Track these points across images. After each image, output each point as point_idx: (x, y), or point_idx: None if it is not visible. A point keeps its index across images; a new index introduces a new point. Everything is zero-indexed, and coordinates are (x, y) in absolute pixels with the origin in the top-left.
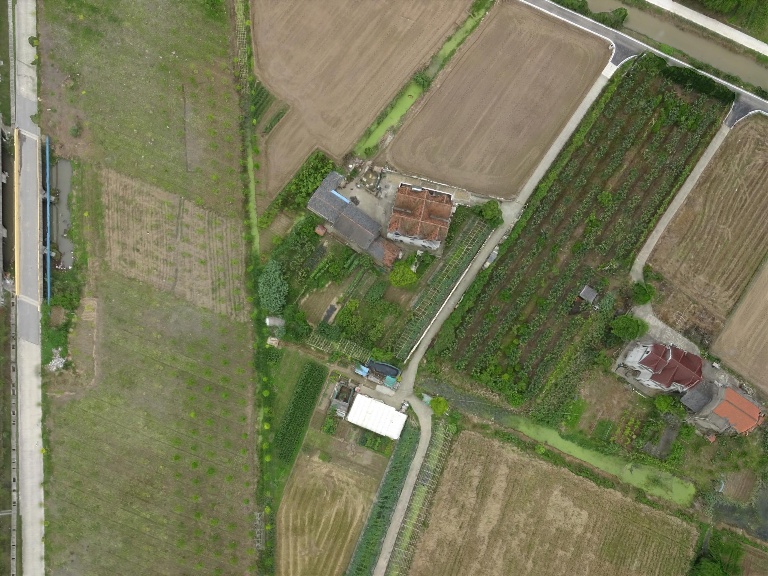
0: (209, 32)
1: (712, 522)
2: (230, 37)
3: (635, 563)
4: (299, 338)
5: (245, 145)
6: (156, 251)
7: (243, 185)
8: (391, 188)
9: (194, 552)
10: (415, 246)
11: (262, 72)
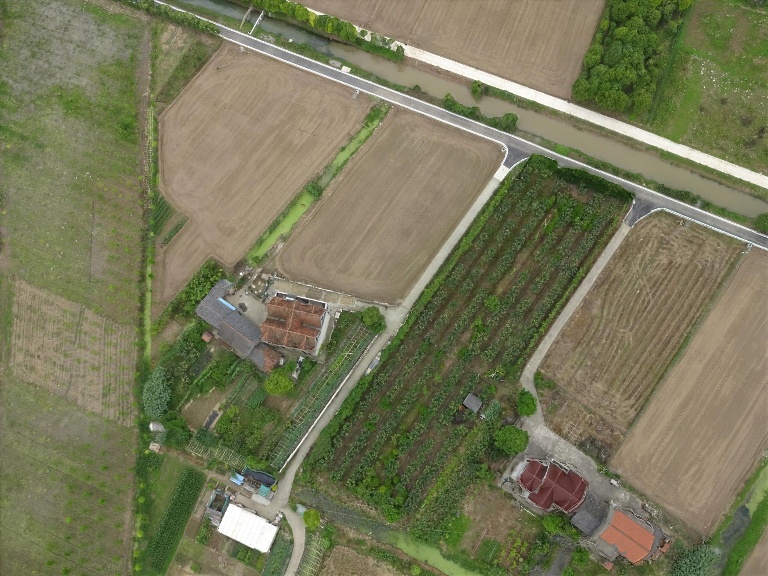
0: (121, 153)
1: None
2: (140, 157)
3: None
4: (180, 444)
5: (145, 256)
6: (55, 357)
7: (140, 293)
8: None
9: None
10: (297, 352)
11: (166, 187)
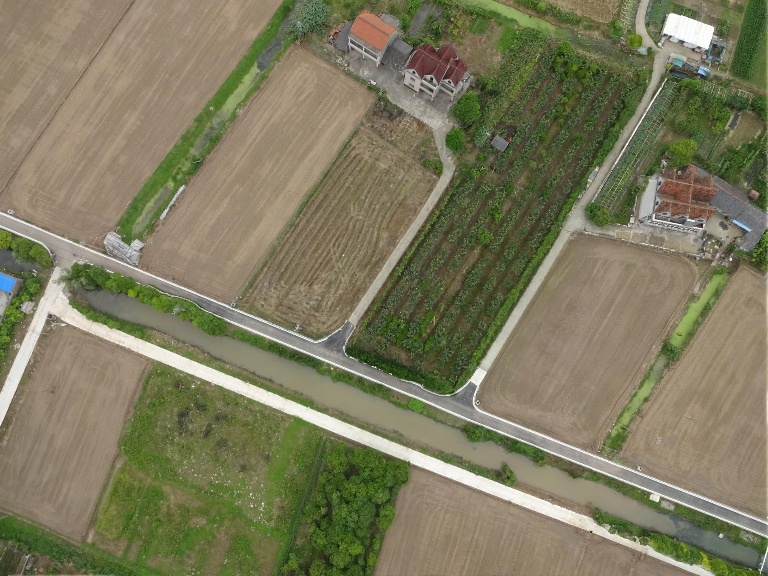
0: None
1: None
2: None
3: None
4: (760, 99)
5: None
6: None
7: None
8: (691, 240)
9: None
10: None
11: None
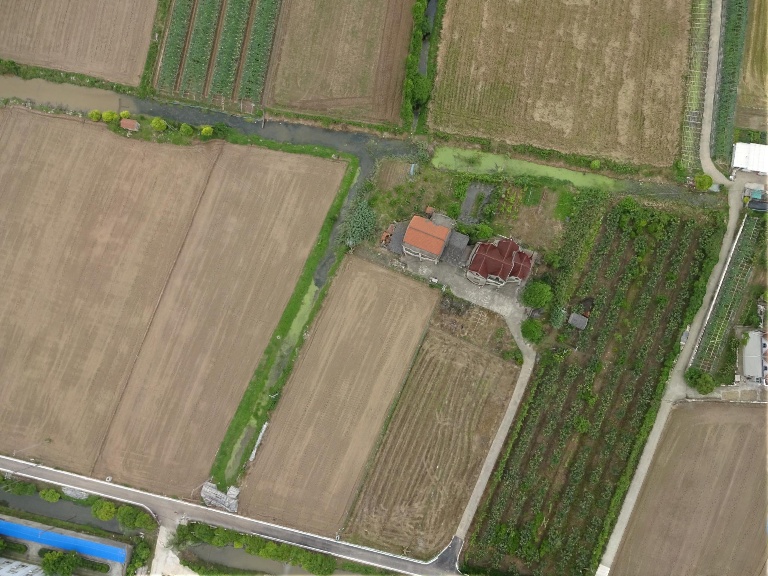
0: None
1: (412, 138)
2: None
3: (480, 87)
4: None
5: None
6: None
7: None
8: None
9: None
10: (767, 331)
11: None
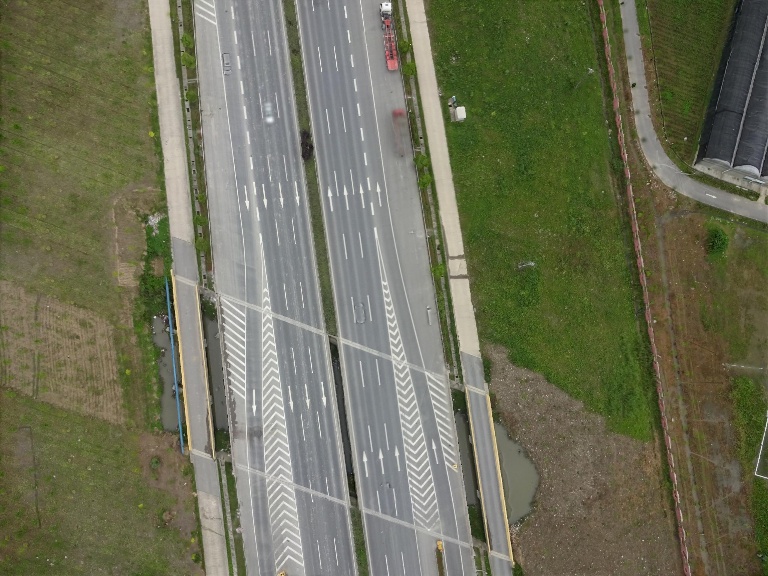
0: None
1: None
2: None
3: None
4: None
5: None
6: (59, 338)
7: None
8: None
9: (2, 39)
10: None
11: None
